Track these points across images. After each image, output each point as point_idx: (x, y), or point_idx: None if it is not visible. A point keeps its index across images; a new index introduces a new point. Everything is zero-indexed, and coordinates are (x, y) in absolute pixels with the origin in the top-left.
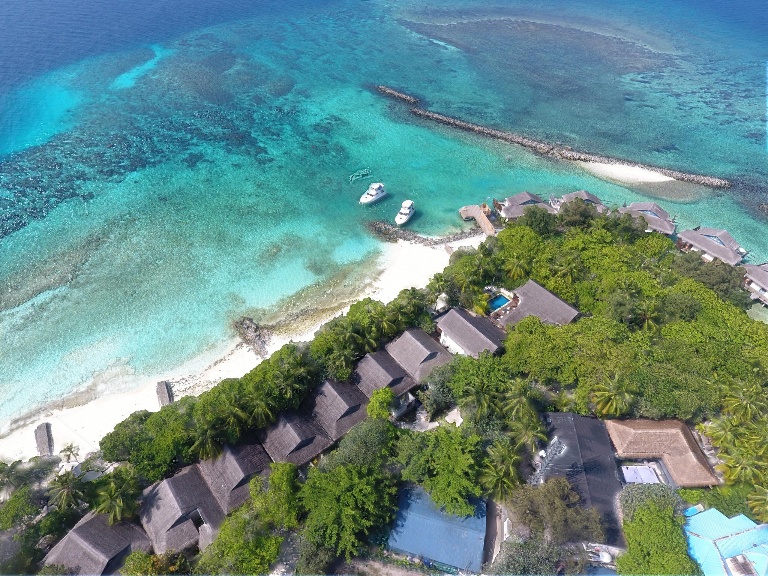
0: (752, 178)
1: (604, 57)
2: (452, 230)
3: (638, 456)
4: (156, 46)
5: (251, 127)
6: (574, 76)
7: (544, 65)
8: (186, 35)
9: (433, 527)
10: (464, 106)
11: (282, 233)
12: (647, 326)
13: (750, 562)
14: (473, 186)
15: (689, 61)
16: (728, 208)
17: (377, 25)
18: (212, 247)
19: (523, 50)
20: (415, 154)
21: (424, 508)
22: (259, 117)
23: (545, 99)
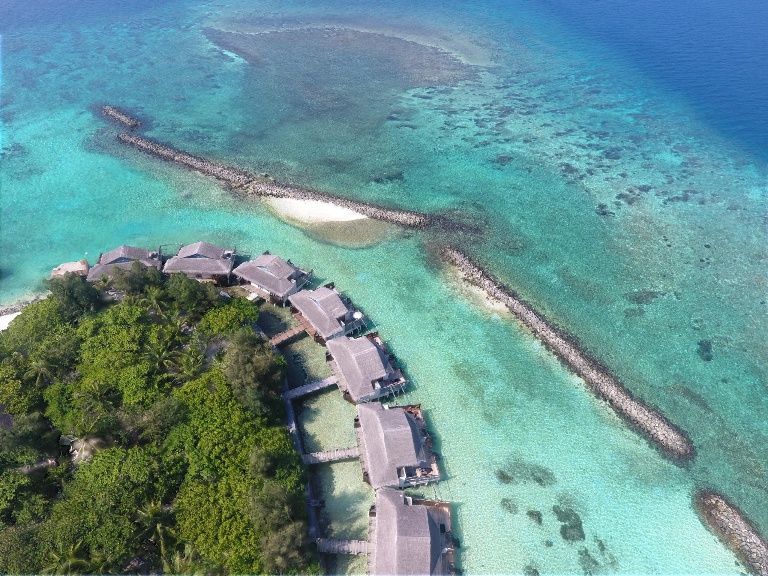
0: (461, 213)
1: (403, 69)
2: (25, 297)
3: None
4: None
5: None
6: (352, 92)
7: (328, 79)
8: None
9: None
10: (191, 129)
11: None
12: (78, 455)
13: None
14: (112, 233)
15: (494, 73)
16: (406, 253)
17: (175, 34)
18: None
19: (319, 62)
20: (76, 192)
21: None
22: None
23: (296, 119)
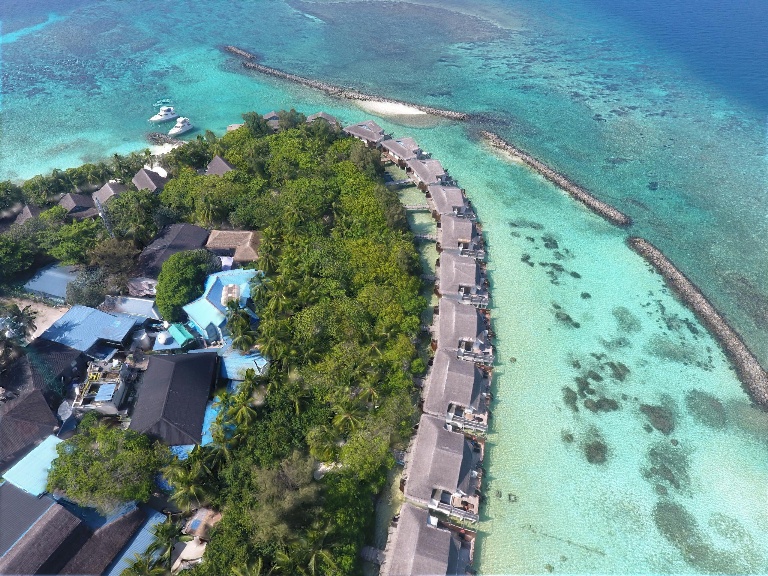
0: (493, 114)
1: (450, 30)
2: None
3: (219, 247)
4: (53, 13)
5: (98, 72)
6: (409, 43)
7: (390, 35)
8: (84, 6)
9: (58, 279)
10: (293, 62)
11: (76, 138)
12: (283, 183)
13: (239, 289)
14: None
15: (524, 35)
16: (454, 132)
17: (264, 2)
18: (14, 145)
19: (381, 24)
20: (224, 93)
21: (59, 271)
22: (110, 65)
23: (368, 59)
